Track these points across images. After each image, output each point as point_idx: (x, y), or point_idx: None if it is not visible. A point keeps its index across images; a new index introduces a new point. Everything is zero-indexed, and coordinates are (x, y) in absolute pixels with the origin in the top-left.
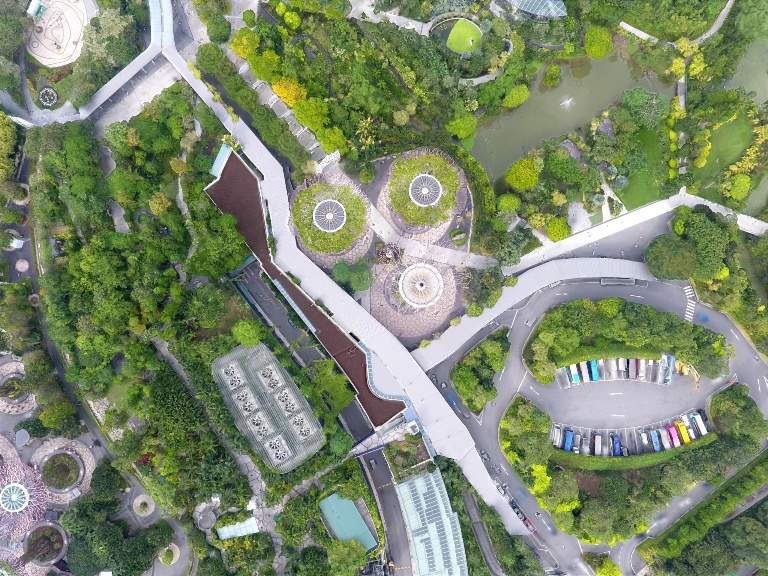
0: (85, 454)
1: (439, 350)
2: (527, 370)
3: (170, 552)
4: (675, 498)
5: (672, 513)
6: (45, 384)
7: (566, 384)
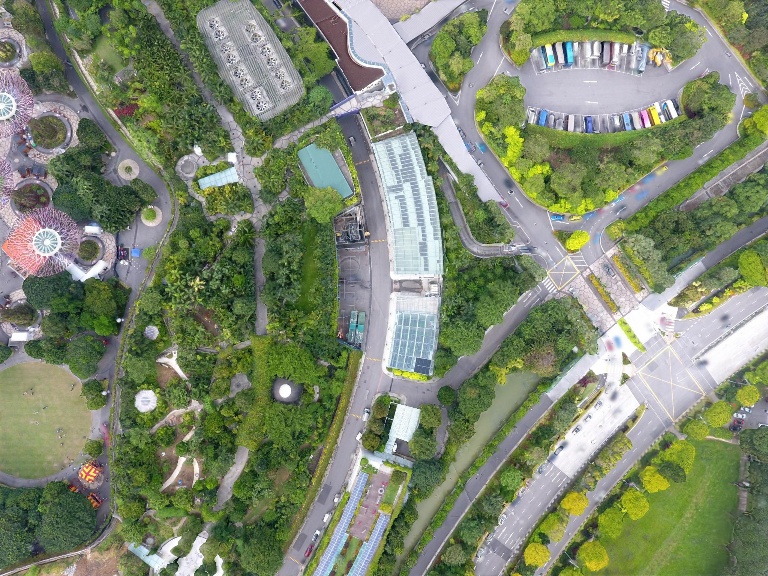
0: (73, 118)
1: (419, 24)
2: (504, 55)
3: (153, 210)
4: (645, 183)
5: (642, 197)
6: (35, 31)
7: (542, 64)
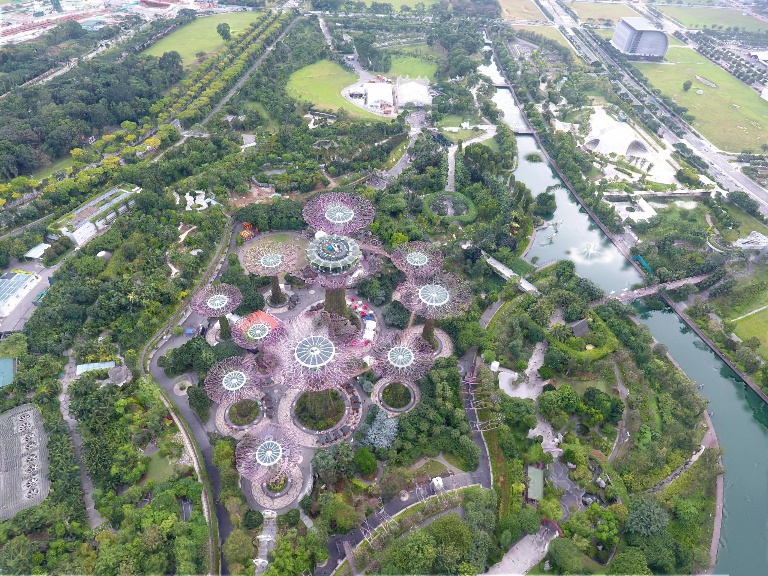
0: (222, 426)
1: None
2: None
3: None
4: None
5: None
6: None
7: None
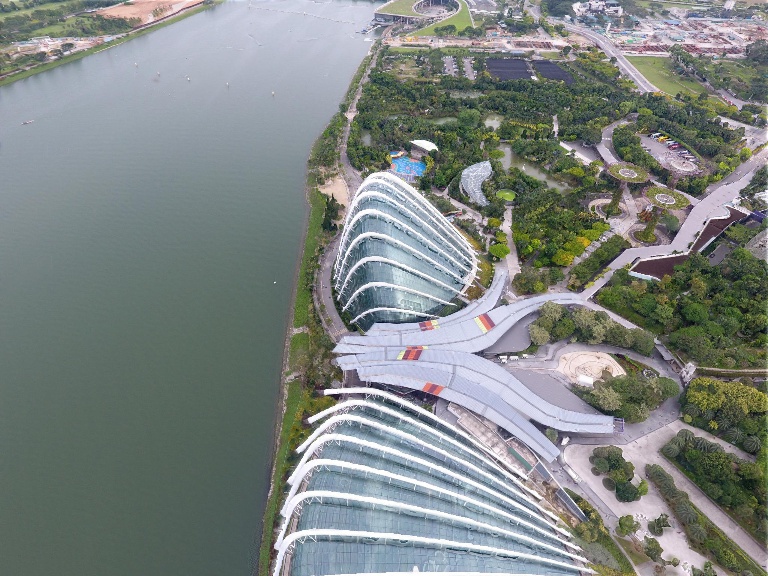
0: None
1: None
2: None
3: None
4: None
5: None
6: None
7: None
